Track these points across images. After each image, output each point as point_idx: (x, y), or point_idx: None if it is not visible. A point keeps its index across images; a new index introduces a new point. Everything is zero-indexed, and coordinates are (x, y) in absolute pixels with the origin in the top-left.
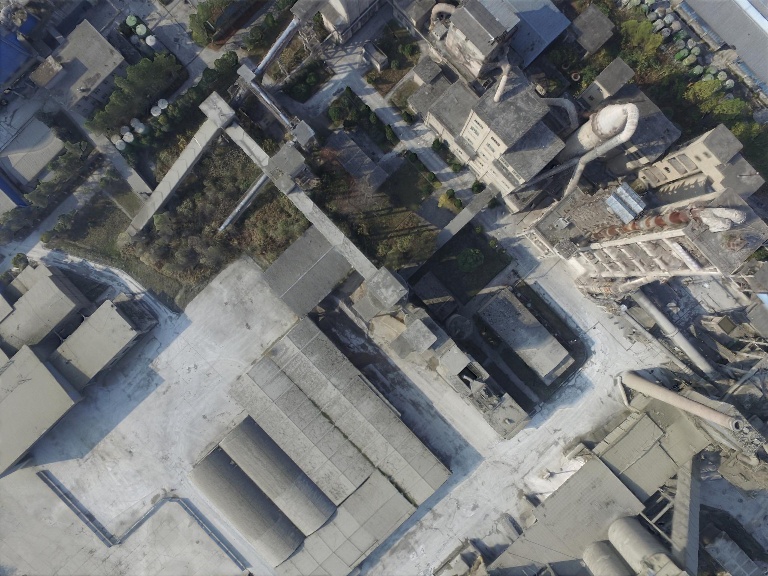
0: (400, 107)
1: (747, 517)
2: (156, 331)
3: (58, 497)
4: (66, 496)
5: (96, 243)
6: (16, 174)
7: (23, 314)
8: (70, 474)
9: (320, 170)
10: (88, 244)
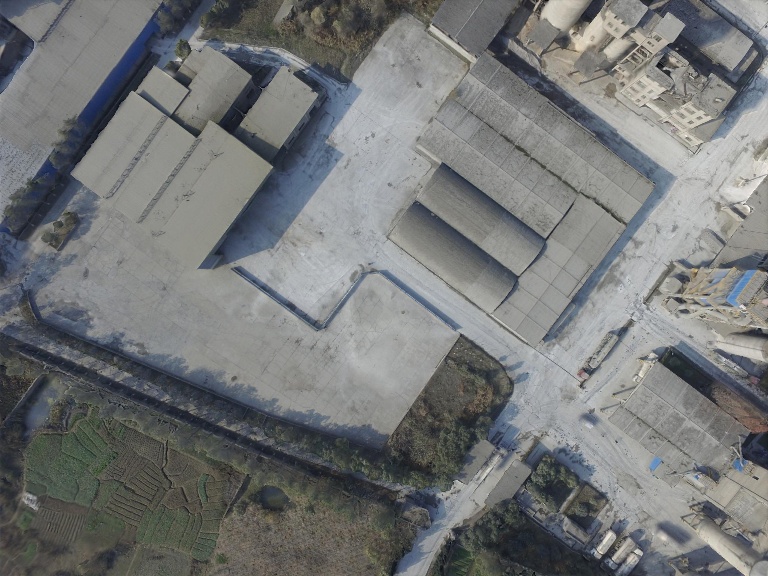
0: None
1: None
2: (327, 106)
3: (256, 290)
4: (263, 289)
5: (252, 26)
6: None
7: (200, 93)
8: (263, 266)
9: None
10: (243, 28)
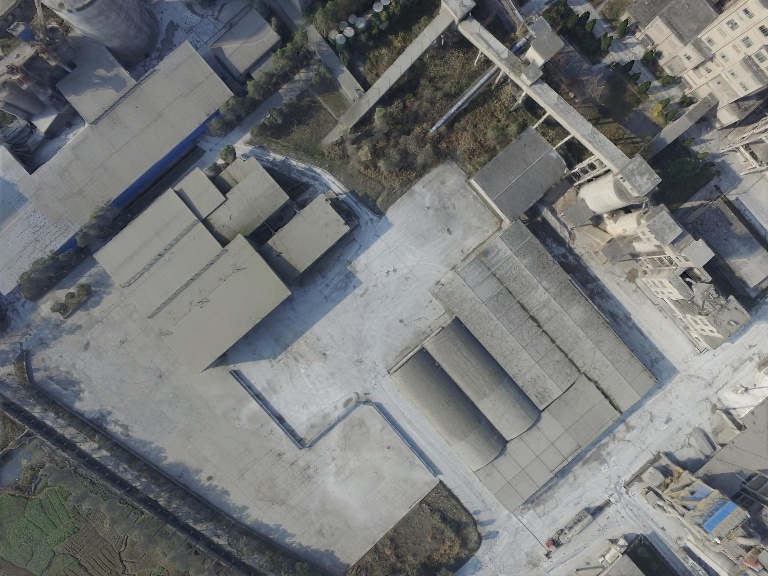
0: (611, 19)
1: None
2: (356, 233)
3: (249, 397)
4: (256, 397)
5: (300, 142)
6: (229, 65)
7: (236, 204)
8: (262, 375)
9: None
10: (291, 142)
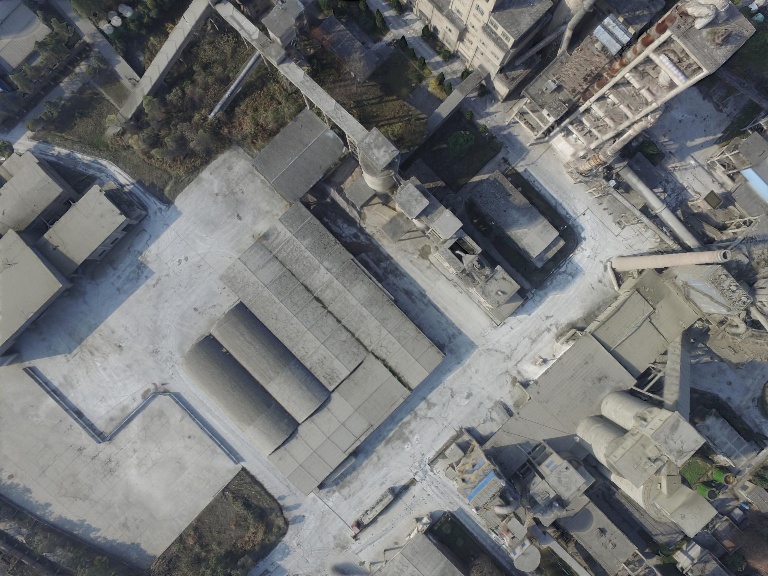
0: None
1: (736, 399)
2: (145, 223)
3: (45, 393)
4: (54, 393)
5: (84, 134)
6: (1, 61)
7: (9, 199)
8: (58, 370)
9: (310, 57)
10: (75, 135)
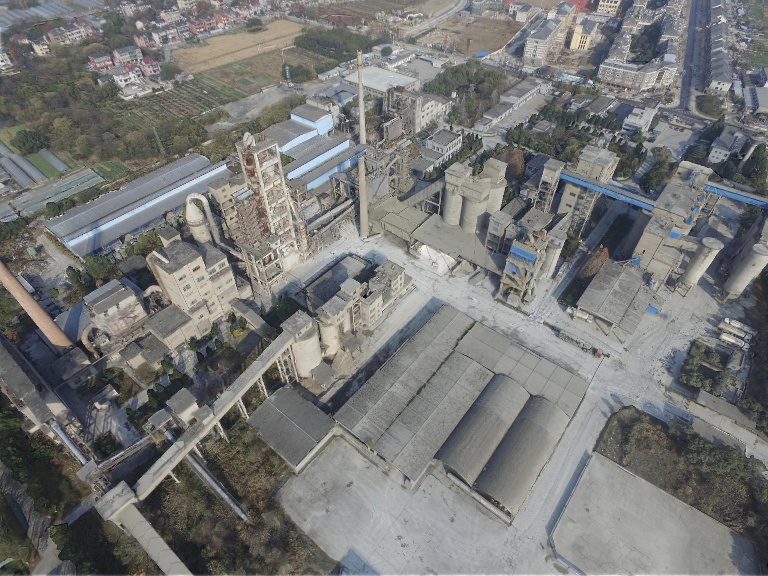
0: (155, 377)
1: None
2: None
3: None
4: None
5: None
6: None
7: None
8: None
9: None
10: None
